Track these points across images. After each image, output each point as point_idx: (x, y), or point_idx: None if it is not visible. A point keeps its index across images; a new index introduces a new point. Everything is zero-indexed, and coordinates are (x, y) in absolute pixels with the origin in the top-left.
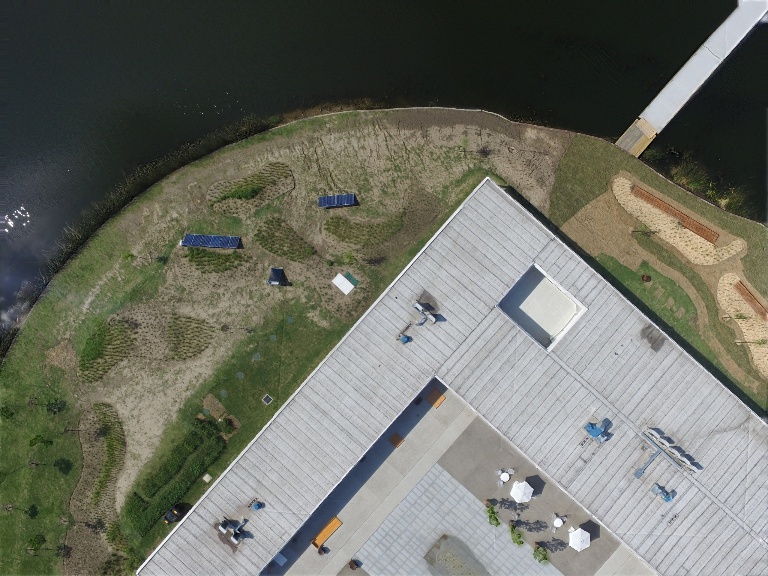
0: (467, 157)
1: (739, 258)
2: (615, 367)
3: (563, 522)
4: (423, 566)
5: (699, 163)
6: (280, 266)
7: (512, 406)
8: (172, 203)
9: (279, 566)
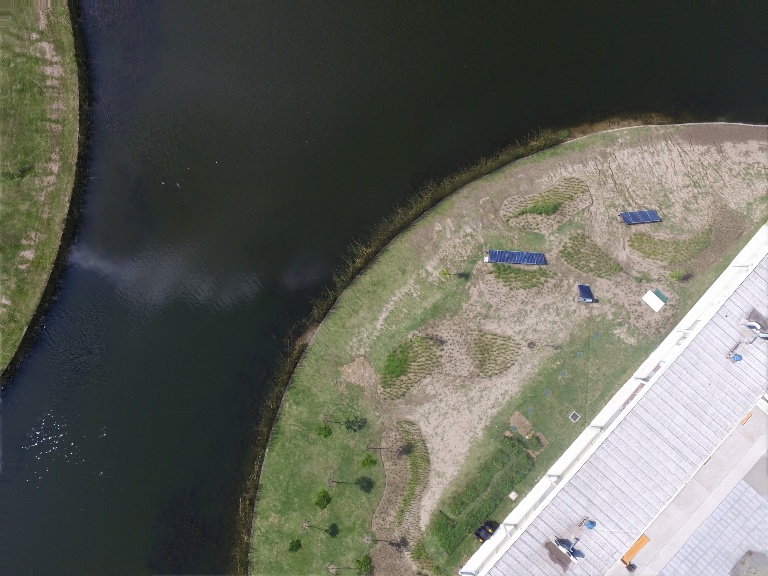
0: (767, 174)
1: None
2: None
3: None
4: None
5: None
6: (586, 283)
7: None
8: (465, 218)
9: None
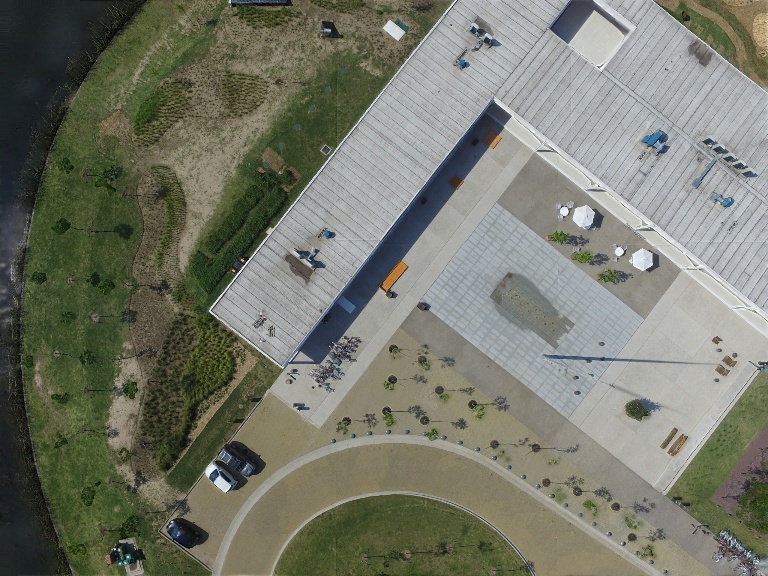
0: None
1: None
2: (666, 82)
3: (624, 251)
4: (490, 305)
5: None
6: (330, 19)
7: (570, 124)
8: None
9: (348, 314)
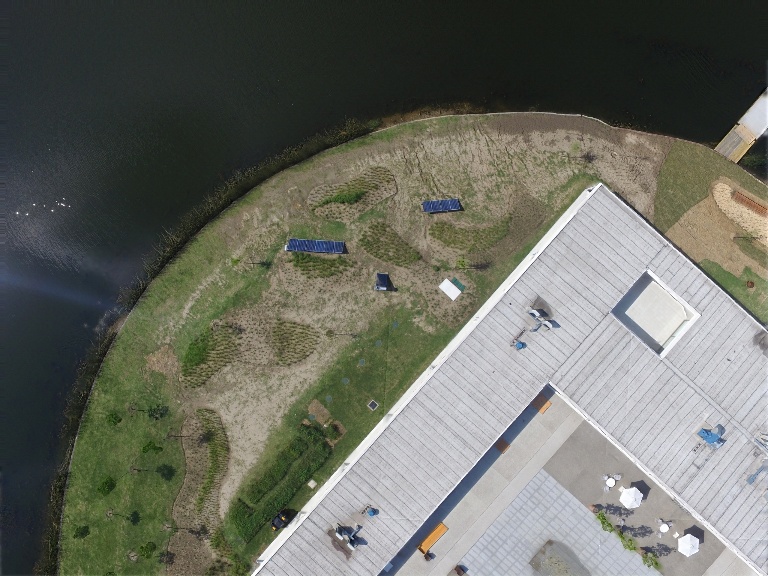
0: (571, 162)
1: None
2: (728, 373)
3: (669, 527)
4: (528, 571)
5: None
6: (385, 271)
7: (626, 412)
8: (272, 207)
9: (385, 572)
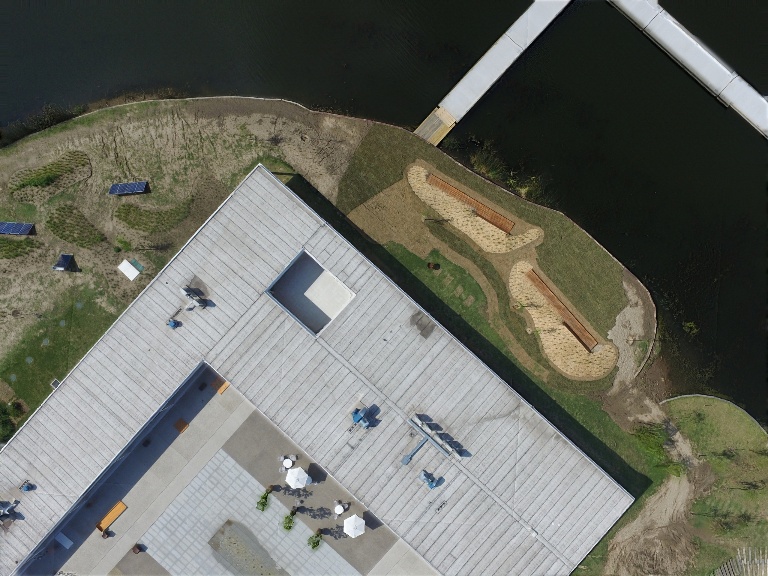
0: (258, 145)
1: (534, 246)
2: (383, 353)
3: (344, 509)
4: (207, 551)
5: (500, 152)
6: (70, 252)
7: (280, 391)
8: None
9: (65, 549)
